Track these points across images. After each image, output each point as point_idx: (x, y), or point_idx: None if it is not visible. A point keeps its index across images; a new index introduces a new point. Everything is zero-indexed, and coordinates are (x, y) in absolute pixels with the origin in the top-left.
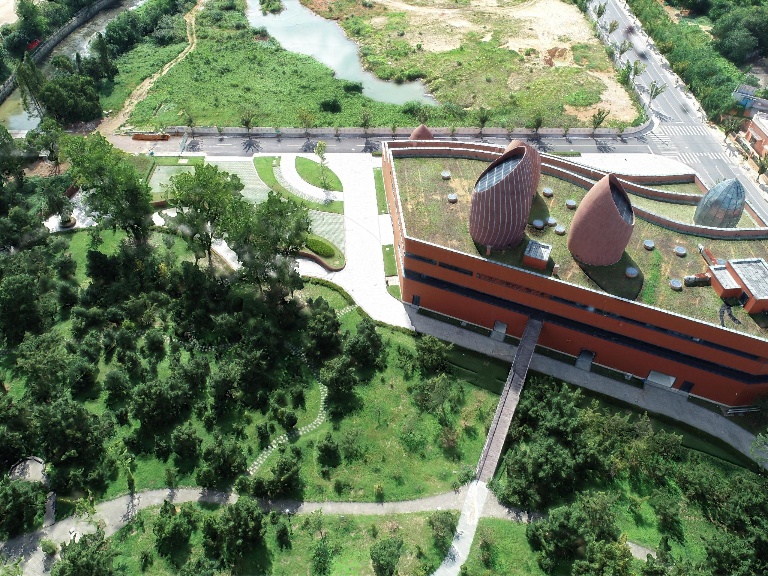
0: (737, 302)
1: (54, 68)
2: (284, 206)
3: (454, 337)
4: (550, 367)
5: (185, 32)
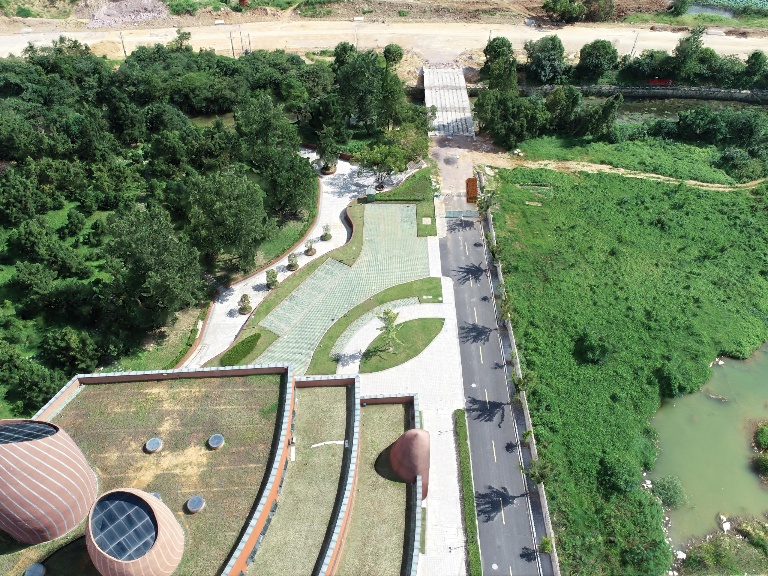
0: None
1: (627, 108)
2: (133, 245)
3: None
4: None
5: (762, 175)
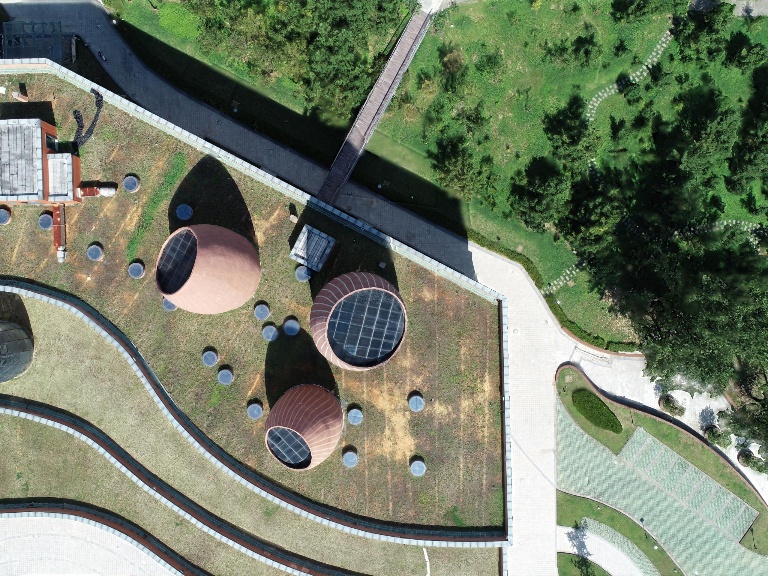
0: (60, 148)
1: None
2: None
3: (419, 229)
4: (308, 175)
5: None
